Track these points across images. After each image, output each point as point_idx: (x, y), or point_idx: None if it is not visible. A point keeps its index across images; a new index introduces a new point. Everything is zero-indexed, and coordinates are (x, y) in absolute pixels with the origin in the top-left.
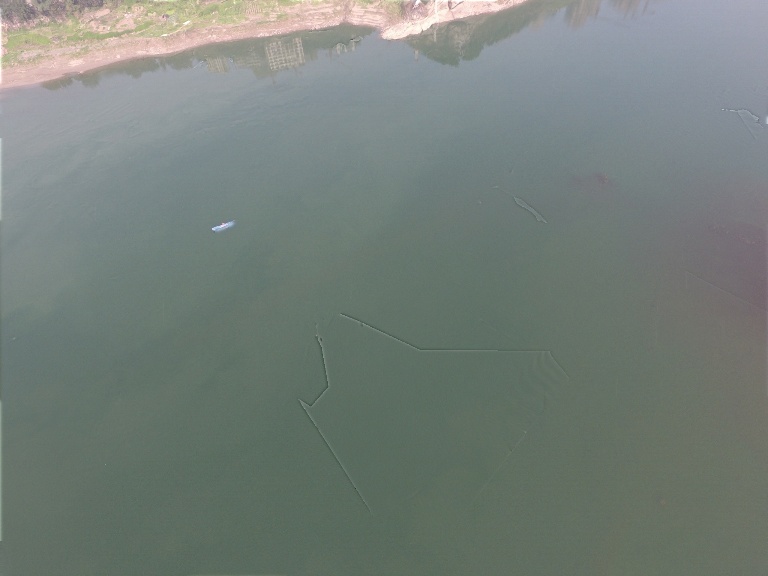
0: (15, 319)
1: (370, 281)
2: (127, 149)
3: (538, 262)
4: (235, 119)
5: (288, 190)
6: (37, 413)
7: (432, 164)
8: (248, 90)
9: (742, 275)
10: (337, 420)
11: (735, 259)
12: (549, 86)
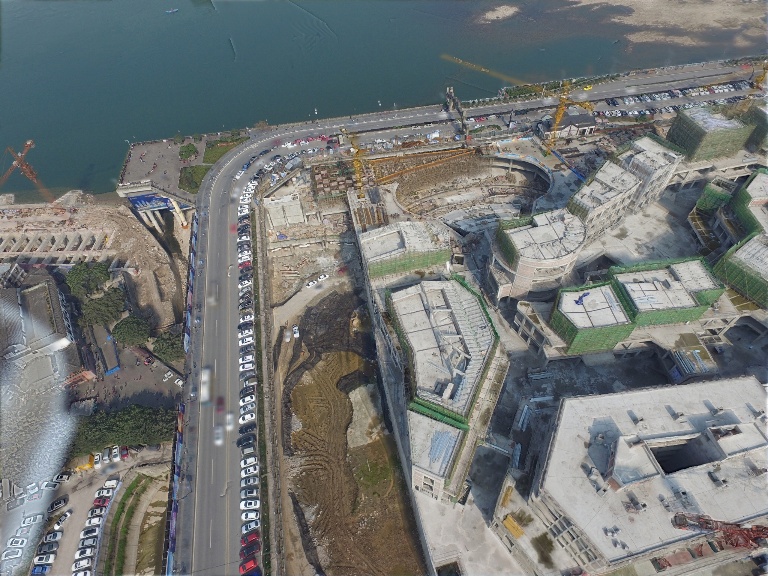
0: (60, 48)
1: None
2: None
3: (340, 15)
4: None
5: None
6: (82, 67)
7: None
8: None
9: (437, 8)
10: None
11: (436, 4)
12: None
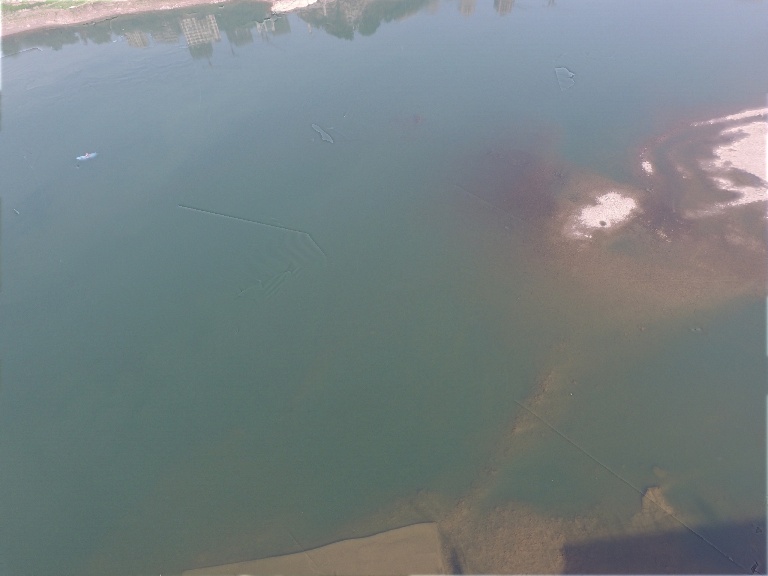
0: None
1: (197, 196)
2: (18, 100)
3: (343, 182)
4: (121, 77)
5: (157, 133)
6: None
7: (274, 108)
8: (140, 53)
9: (498, 187)
10: (57, 234)
11: (498, 176)
12: (398, 48)
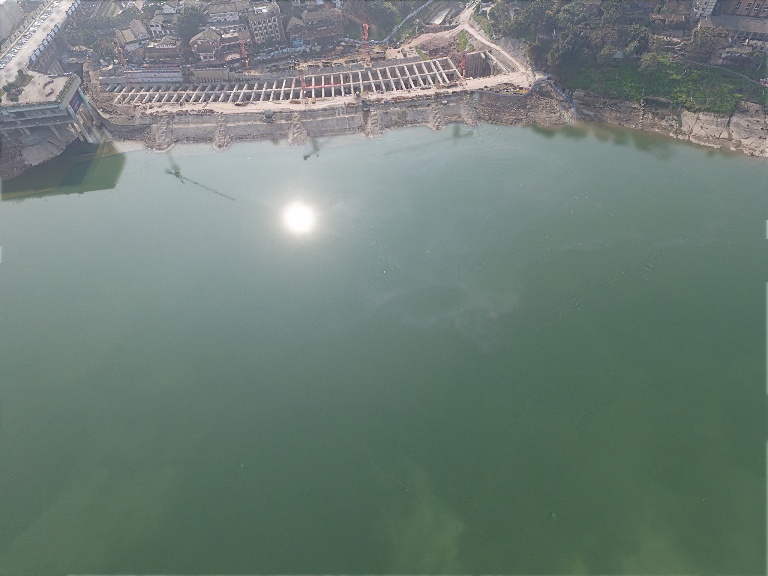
0: (254, 497)
1: None
2: None
3: None
4: None
5: None
6: (180, 380)
7: None
8: None
9: None
10: None
11: None
12: None
